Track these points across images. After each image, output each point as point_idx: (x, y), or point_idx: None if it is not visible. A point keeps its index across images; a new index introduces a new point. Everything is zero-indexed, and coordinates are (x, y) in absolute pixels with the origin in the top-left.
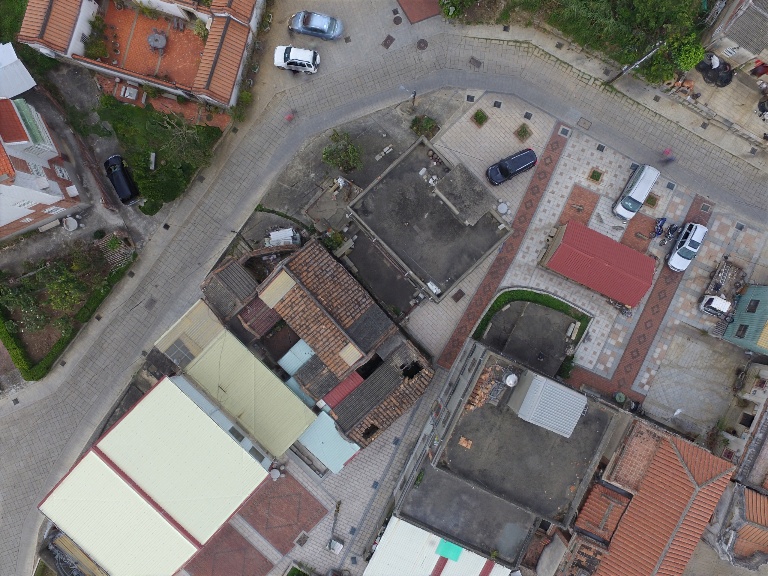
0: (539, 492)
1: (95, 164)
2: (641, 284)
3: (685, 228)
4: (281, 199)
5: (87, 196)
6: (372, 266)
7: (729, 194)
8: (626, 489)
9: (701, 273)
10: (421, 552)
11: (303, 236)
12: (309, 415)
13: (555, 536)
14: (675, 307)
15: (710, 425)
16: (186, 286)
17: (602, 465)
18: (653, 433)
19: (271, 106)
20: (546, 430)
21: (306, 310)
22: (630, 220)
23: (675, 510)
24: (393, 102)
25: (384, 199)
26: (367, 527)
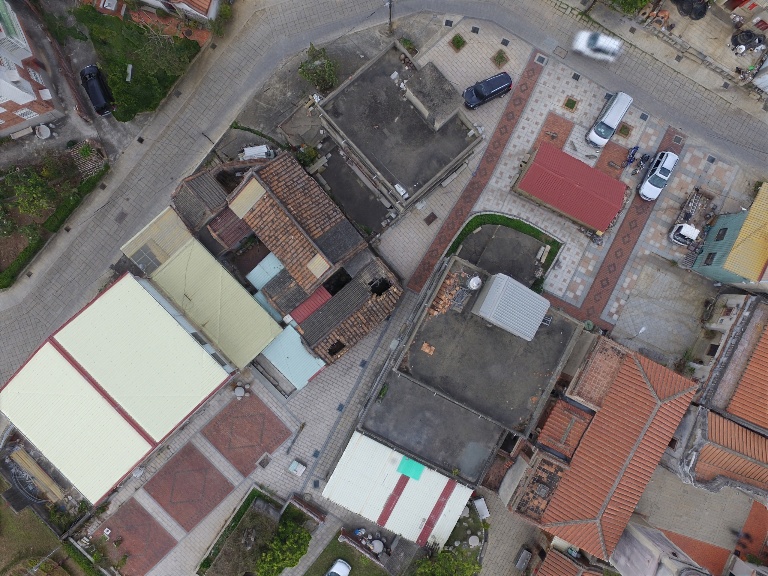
0: (501, 402)
1: (71, 74)
2: (611, 206)
3: (657, 157)
4: (257, 117)
5: (62, 106)
6: (345, 185)
7: (701, 127)
8: (589, 404)
9: (672, 204)
10: (383, 469)
11: (277, 154)
12: (275, 327)
13: (518, 457)
14: (646, 237)
15: (678, 357)
16: (158, 200)
17: (566, 383)
18: (617, 350)
19: (250, 23)
20: (509, 339)
21: (275, 220)
22: (603, 149)
23: (637, 425)
24: (372, 24)
25: (355, 101)
26: (331, 450)
